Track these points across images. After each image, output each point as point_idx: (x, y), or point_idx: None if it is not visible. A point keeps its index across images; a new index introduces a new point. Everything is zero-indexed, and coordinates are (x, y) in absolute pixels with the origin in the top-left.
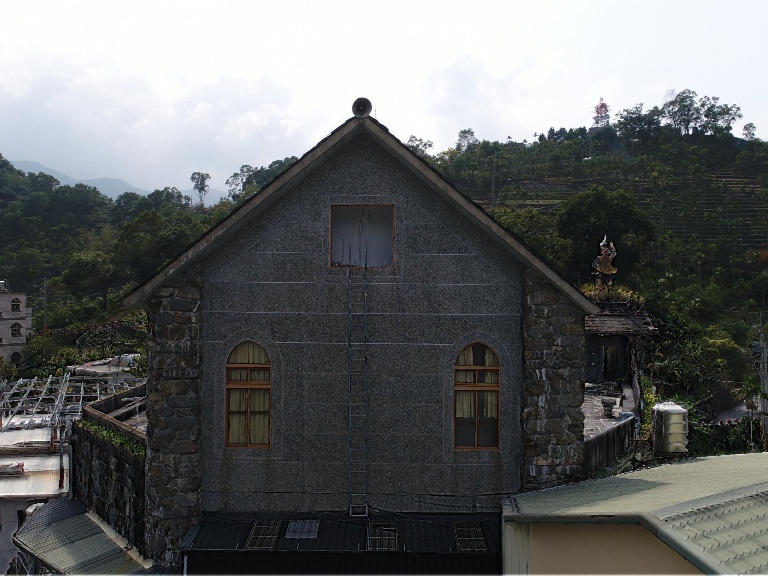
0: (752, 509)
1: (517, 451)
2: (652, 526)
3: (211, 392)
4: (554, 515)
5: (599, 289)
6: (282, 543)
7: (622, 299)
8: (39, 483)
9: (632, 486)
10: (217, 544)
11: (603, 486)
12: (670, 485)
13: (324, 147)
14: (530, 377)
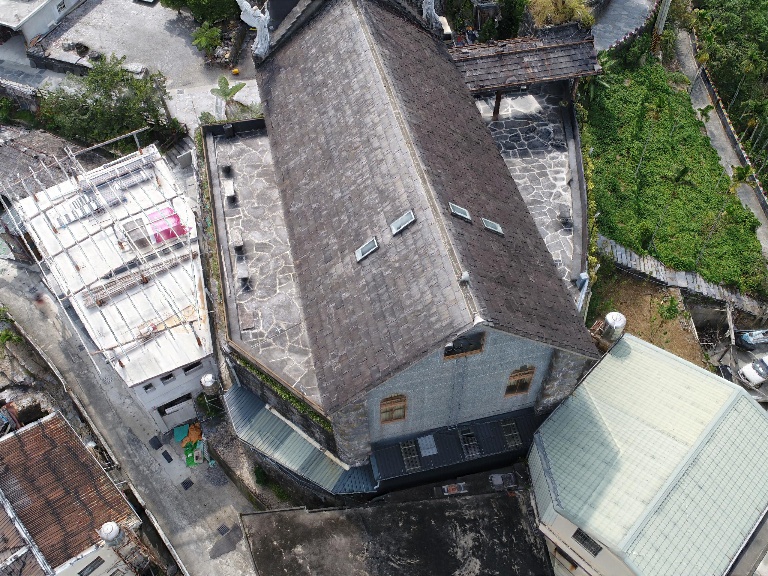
0: (656, 522)
1: (537, 391)
2: (623, 560)
3: (372, 413)
4: (582, 529)
5: (555, 3)
6: (423, 462)
7: (575, 19)
8: (179, 341)
9: (602, 445)
10: (392, 471)
11: (585, 429)
12: (621, 461)
13: (452, 340)
14: (553, 377)
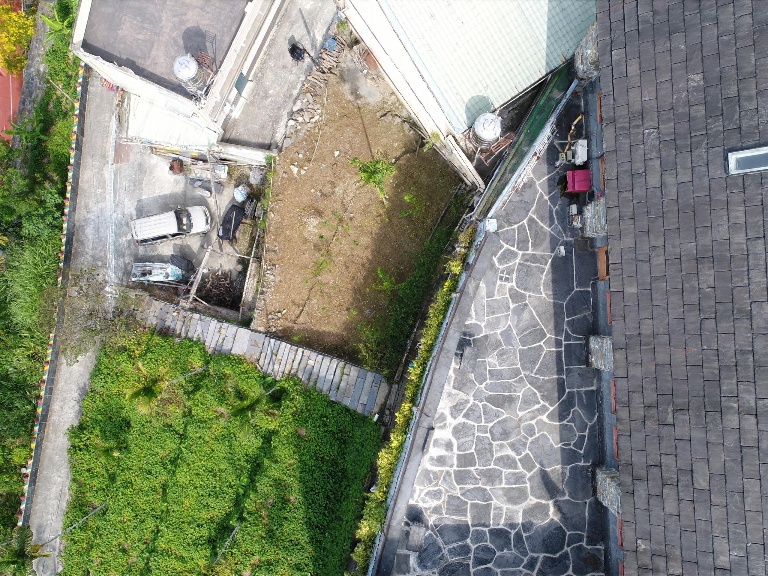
0: None
1: None
2: None
3: None
4: None
5: None
6: None
7: None
8: None
9: None
10: None
11: (574, 2)
12: None
13: None
14: None
